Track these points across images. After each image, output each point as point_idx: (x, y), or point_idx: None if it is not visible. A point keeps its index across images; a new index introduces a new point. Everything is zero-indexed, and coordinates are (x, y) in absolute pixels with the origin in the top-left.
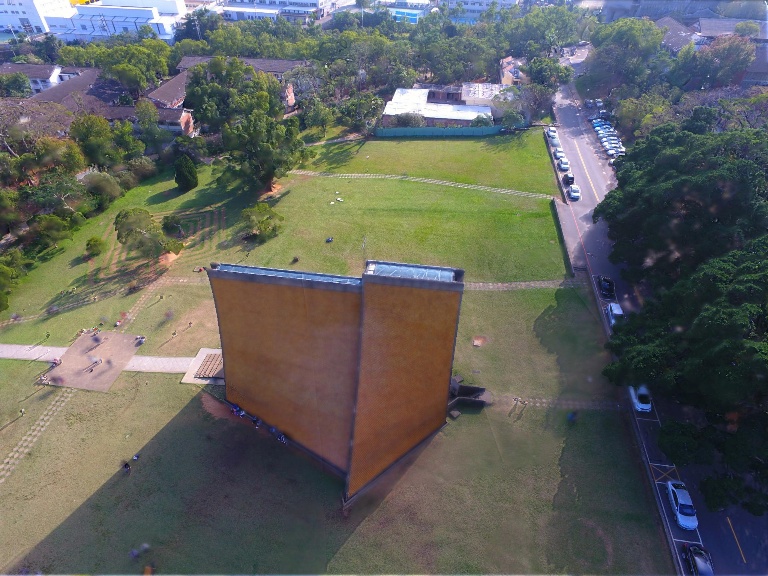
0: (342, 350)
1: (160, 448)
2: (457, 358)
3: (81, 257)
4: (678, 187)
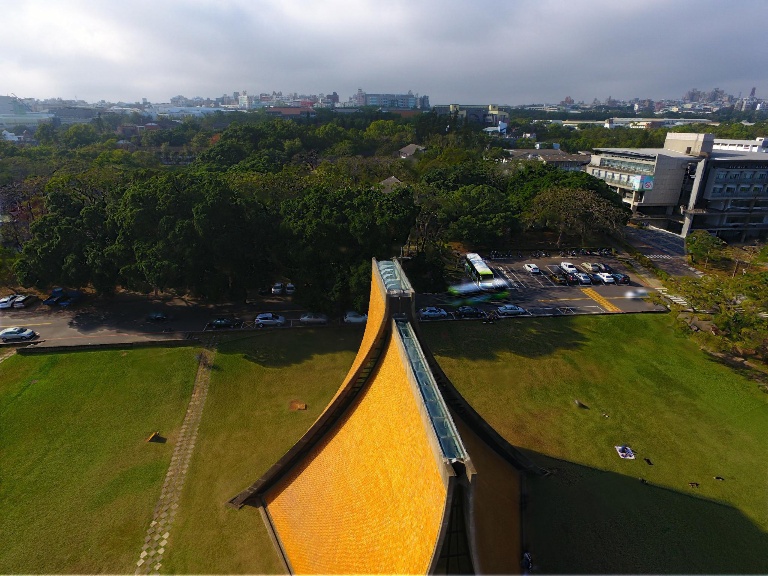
0: None
1: None
2: None
3: None
4: (208, 212)
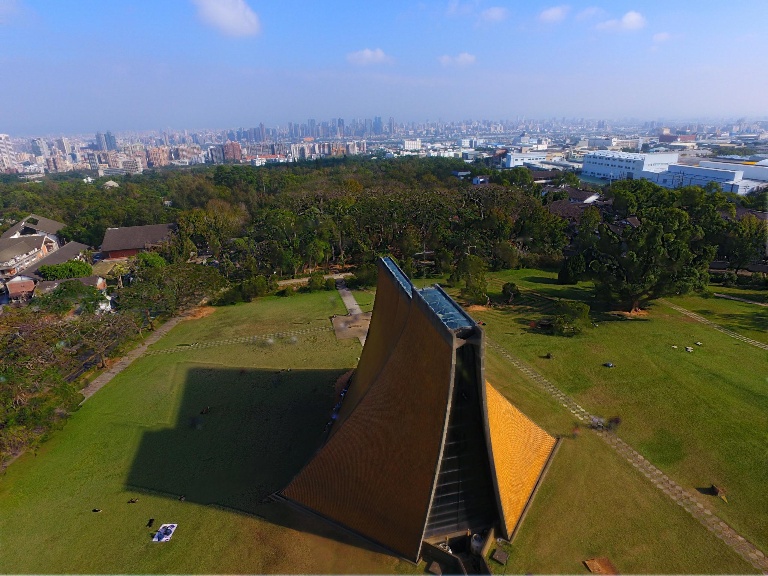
0: None
1: (300, 375)
2: (539, 545)
3: (442, 284)
4: None
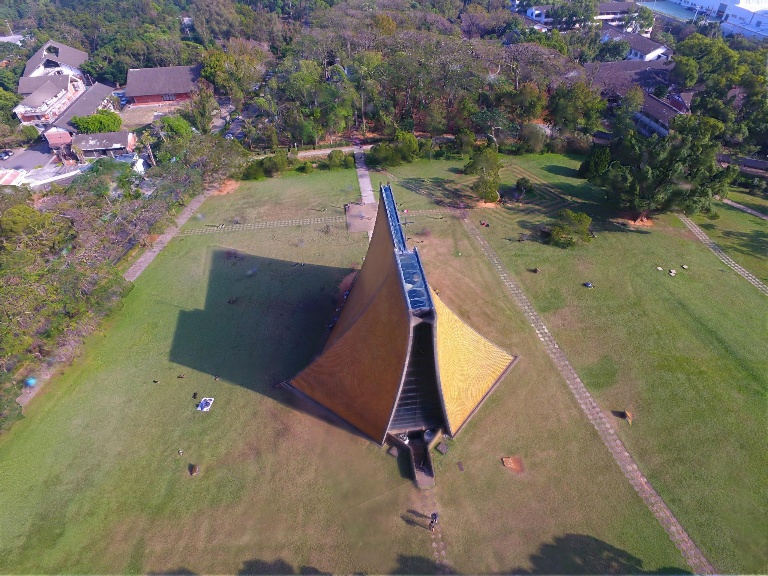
0: None
1: (311, 271)
2: (473, 443)
3: (459, 169)
4: None
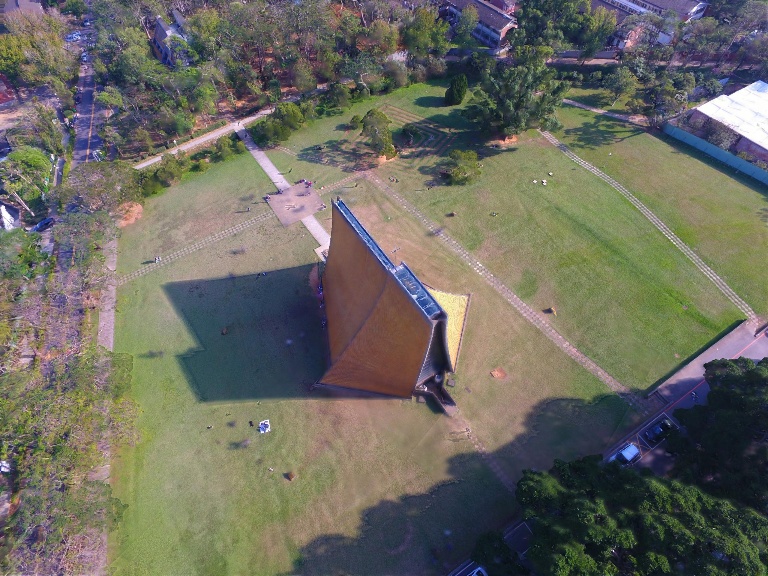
0: (370, 303)
1: (276, 278)
2: (469, 370)
3: (345, 125)
4: None
